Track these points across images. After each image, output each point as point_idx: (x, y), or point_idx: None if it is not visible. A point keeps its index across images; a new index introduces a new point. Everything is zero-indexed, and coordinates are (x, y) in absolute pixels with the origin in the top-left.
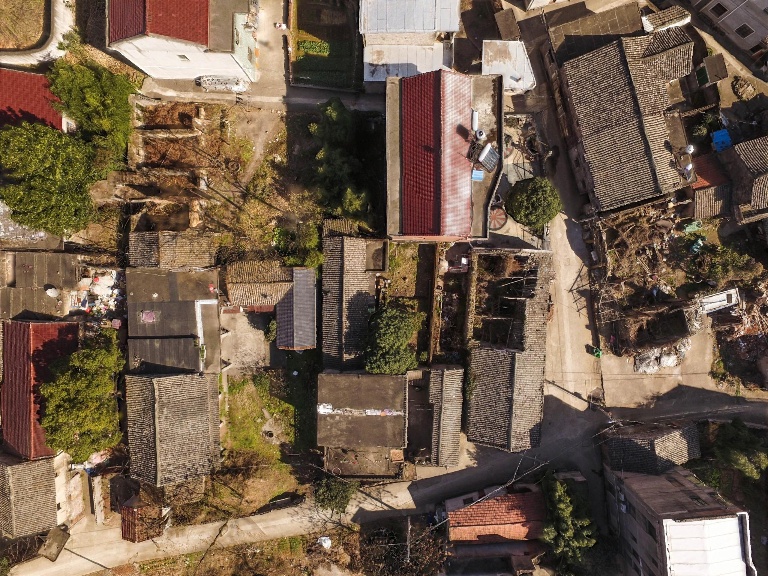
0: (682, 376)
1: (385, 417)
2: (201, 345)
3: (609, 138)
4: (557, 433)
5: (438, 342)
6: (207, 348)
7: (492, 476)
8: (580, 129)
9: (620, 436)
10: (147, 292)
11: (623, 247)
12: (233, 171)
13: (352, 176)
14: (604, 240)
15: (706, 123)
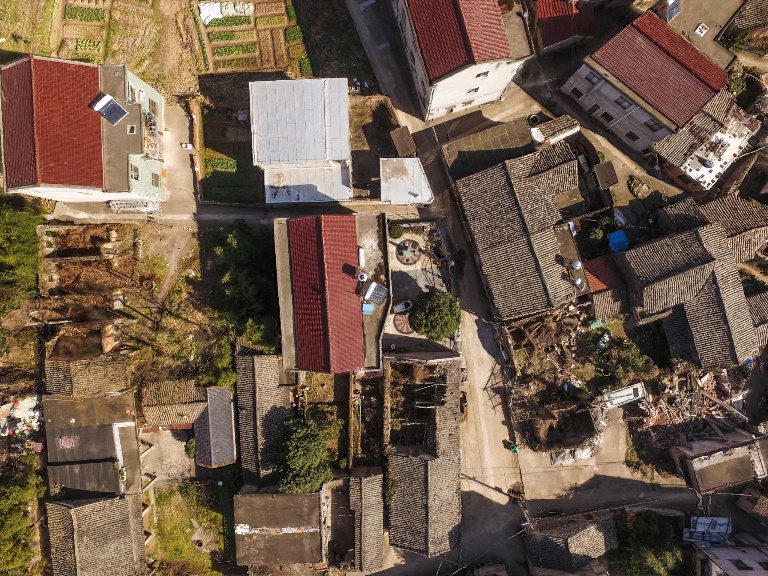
0: (598, 466)
1: (301, 534)
2: (121, 468)
3: (503, 253)
4: (480, 527)
5: (359, 444)
6: (127, 470)
7: (420, 573)
8: (476, 243)
9: (538, 532)
10: (65, 418)
11: (531, 346)
12: (148, 289)
13: (260, 296)
14: (510, 344)
15: (602, 225)
